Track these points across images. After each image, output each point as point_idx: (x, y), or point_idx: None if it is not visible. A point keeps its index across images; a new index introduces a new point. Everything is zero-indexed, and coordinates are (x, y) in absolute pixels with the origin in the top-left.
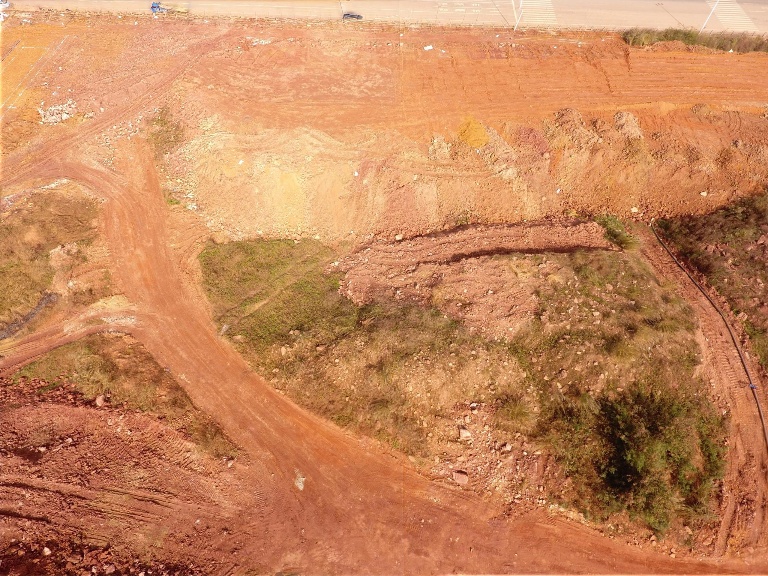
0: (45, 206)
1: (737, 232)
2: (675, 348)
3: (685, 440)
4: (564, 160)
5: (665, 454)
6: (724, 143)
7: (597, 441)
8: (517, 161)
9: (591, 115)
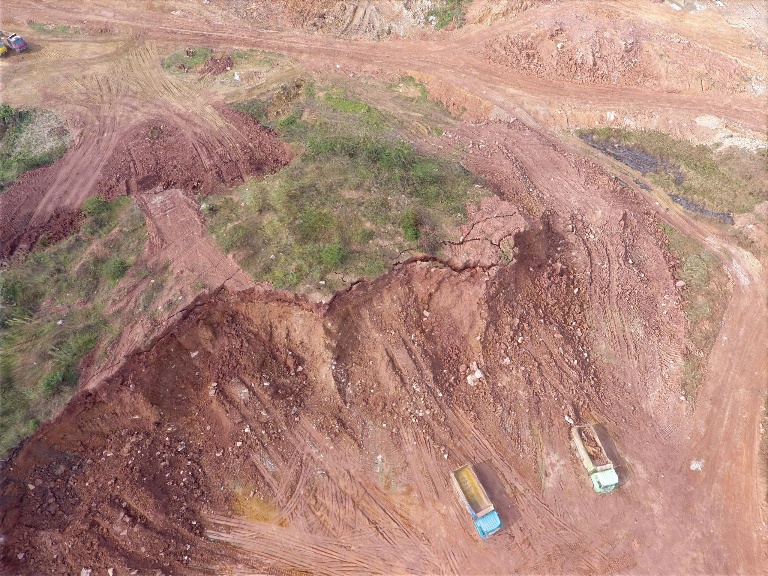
0: None
1: None
2: None
3: None
4: None
5: None
6: None
7: None
8: None
9: None
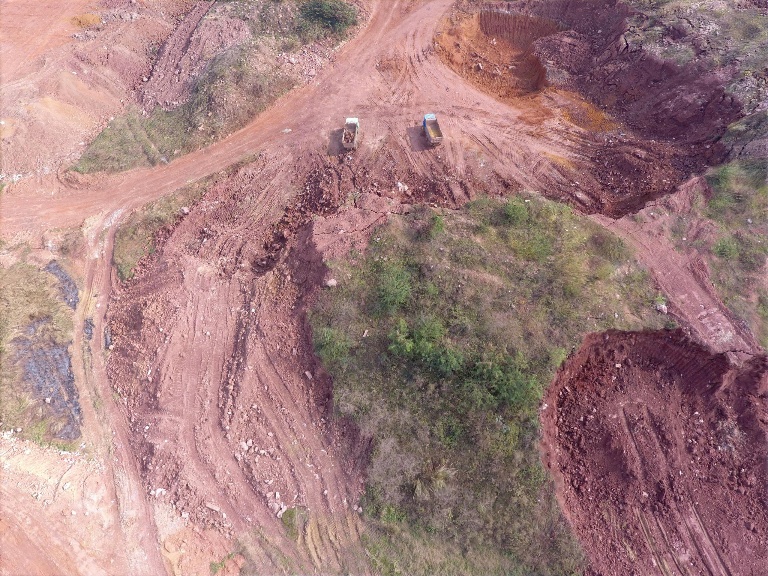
0: None
1: None
2: None
3: None
4: None
5: (329, 7)
6: None
7: (316, 24)
8: None
9: None
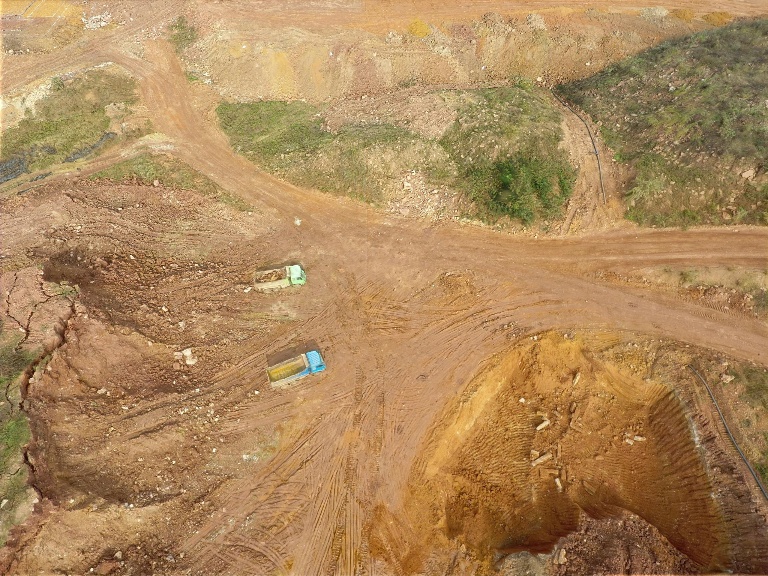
0: (98, 78)
1: (606, 82)
2: (546, 131)
3: (548, 178)
4: (487, 44)
5: (534, 184)
6: (606, 33)
7: (492, 183)
8: (451, 45)
9: (509, 17)
